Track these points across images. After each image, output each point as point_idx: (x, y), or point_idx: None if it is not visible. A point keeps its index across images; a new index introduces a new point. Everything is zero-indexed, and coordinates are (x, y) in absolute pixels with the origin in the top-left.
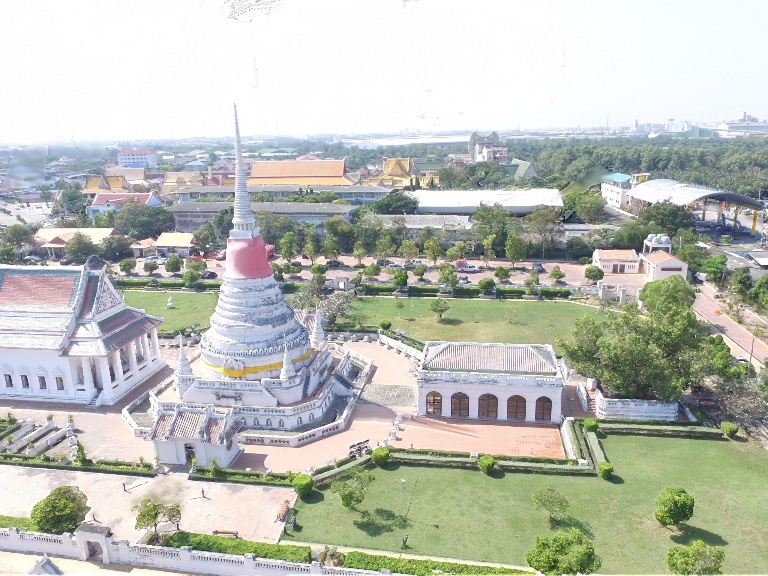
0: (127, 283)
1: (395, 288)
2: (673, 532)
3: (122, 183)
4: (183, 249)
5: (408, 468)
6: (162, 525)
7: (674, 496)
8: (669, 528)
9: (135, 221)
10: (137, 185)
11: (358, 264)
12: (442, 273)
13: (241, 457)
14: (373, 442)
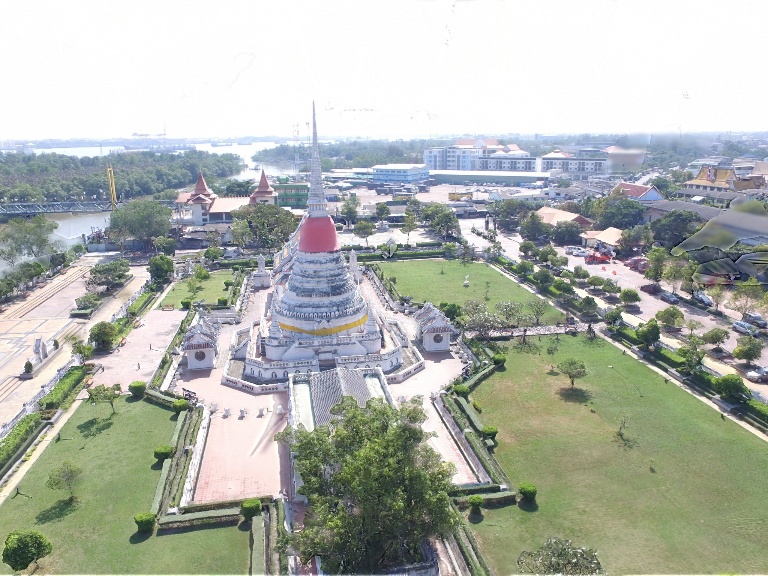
0: (499, 260)
1: (641, 341)
2: (26, 575)
3: (729, 177)
4: (610, 246)
5: (174, 425)
6: (110, 366)
7: (19, 534)
8: (33, 573)
9: (604, 212)
10: (746, 181)
11: (714, 309)
12: (690, 343)
13: (205, 370)
14: (234, 408)
